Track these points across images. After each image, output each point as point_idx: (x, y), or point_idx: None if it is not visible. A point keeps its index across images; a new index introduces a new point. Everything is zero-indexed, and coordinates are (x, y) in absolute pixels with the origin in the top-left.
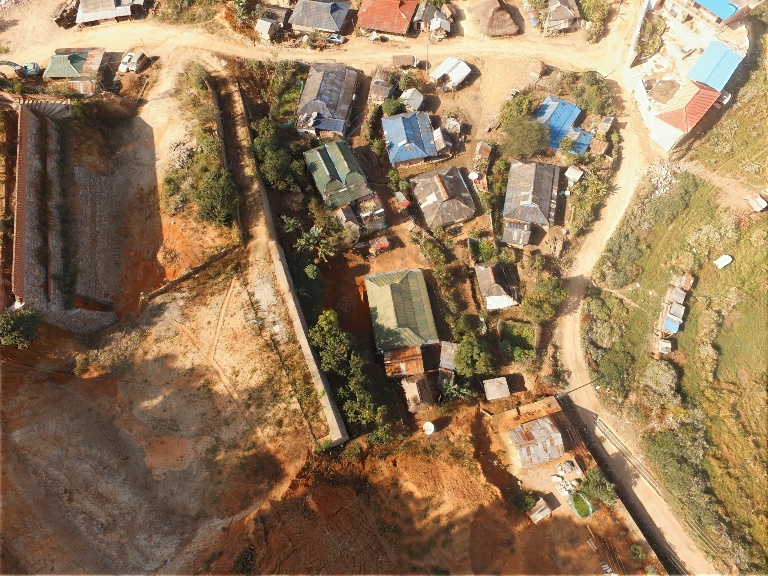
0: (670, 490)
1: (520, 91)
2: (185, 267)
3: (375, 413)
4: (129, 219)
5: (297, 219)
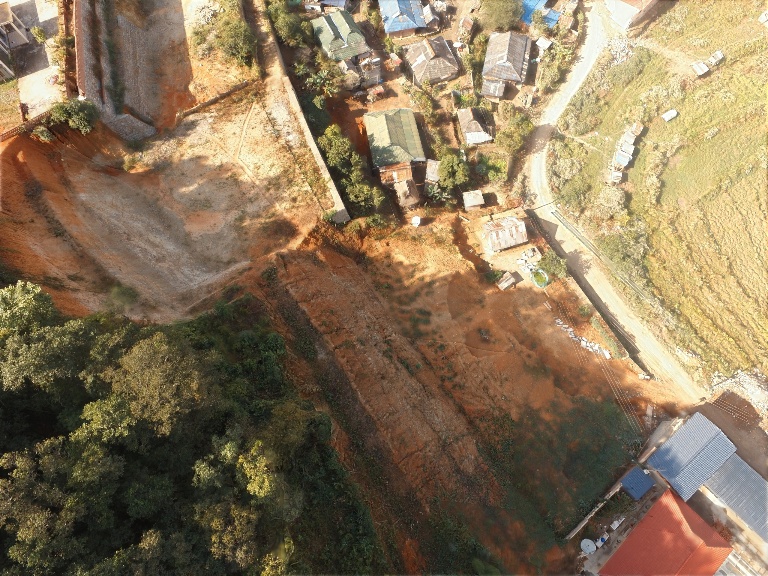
0: (615, 276)
1: None
2: (212, 96)
3: (372, 188)
4: (163, 63)
5: (306, 65)
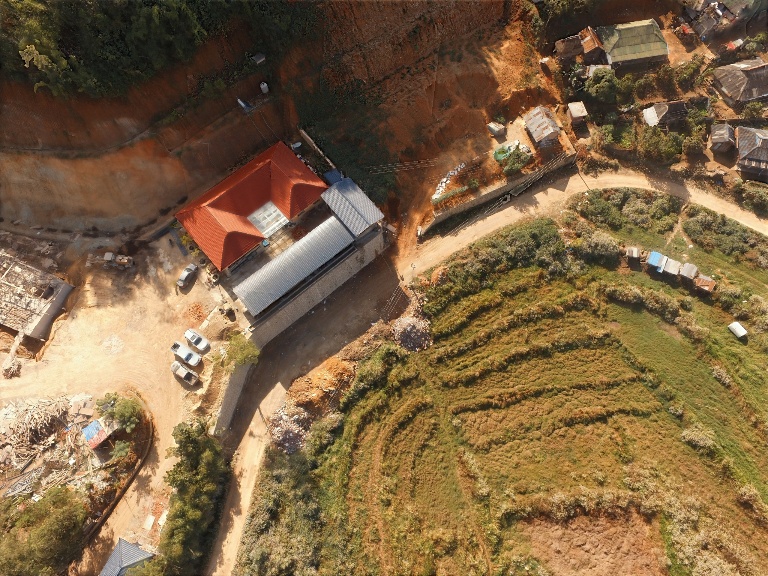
0: None
1: None
2: None
3: None
4: None
5: None
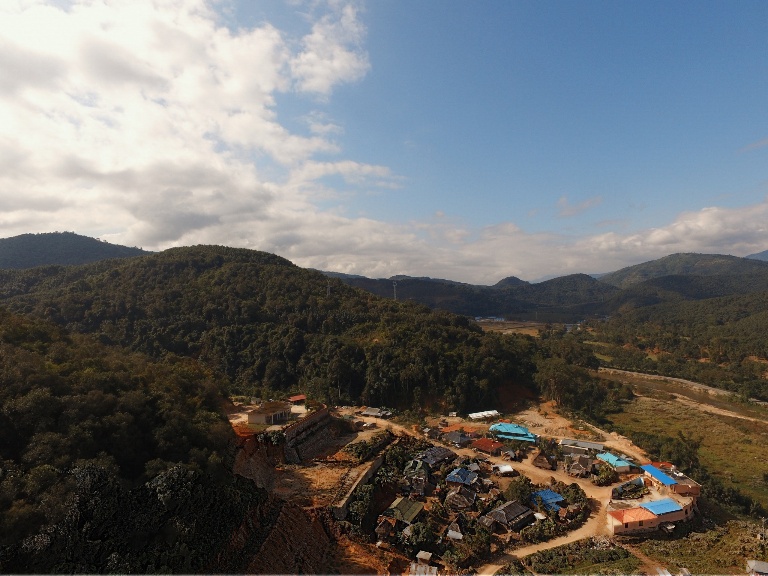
0: None
1: (535, 485)
2: None
3: None
4: None
5: None
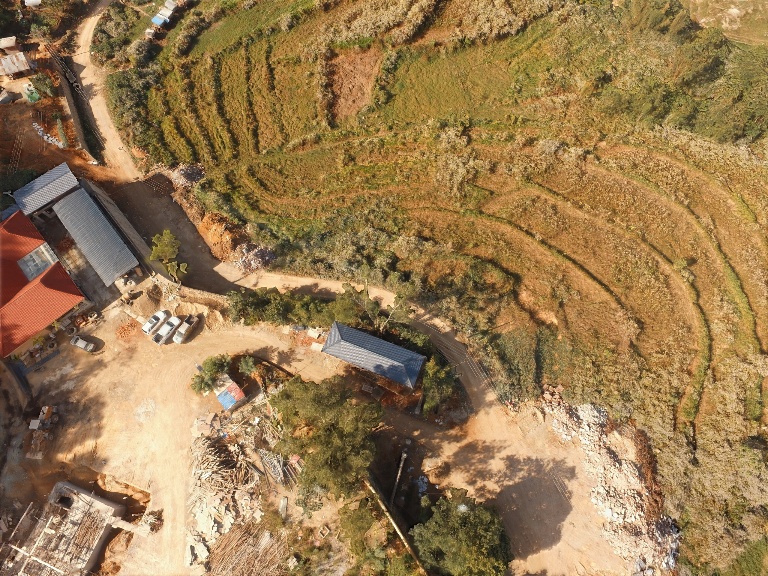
0: (111, 100)
1: None
2: None
3: None
4: None
5: None
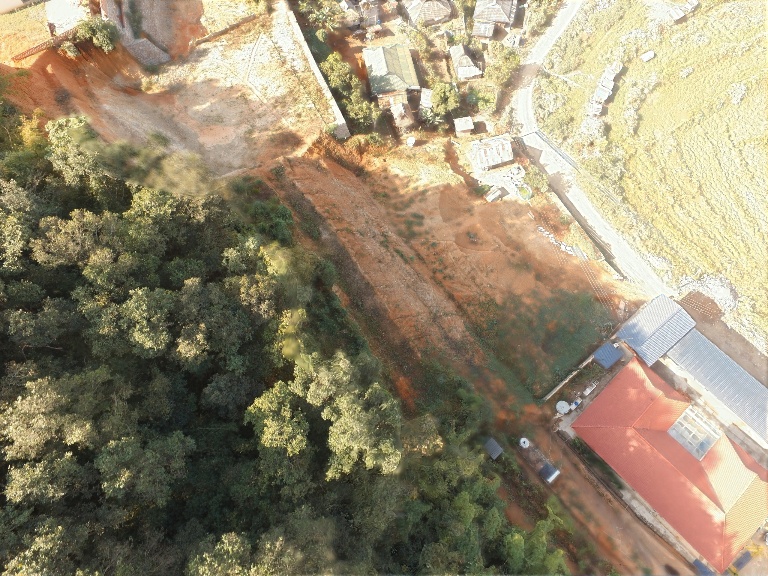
0: (594, 194)
1: None
2: None
3: (370, 103)
4: None
5: (309, 3)
